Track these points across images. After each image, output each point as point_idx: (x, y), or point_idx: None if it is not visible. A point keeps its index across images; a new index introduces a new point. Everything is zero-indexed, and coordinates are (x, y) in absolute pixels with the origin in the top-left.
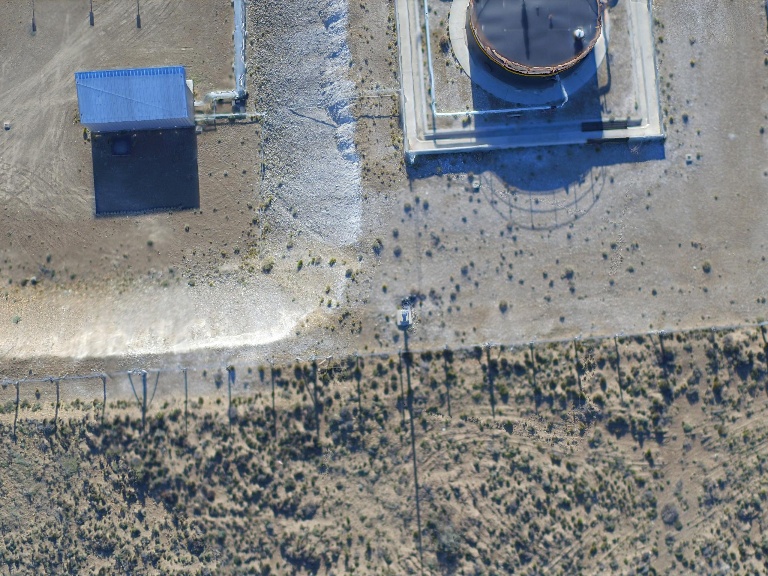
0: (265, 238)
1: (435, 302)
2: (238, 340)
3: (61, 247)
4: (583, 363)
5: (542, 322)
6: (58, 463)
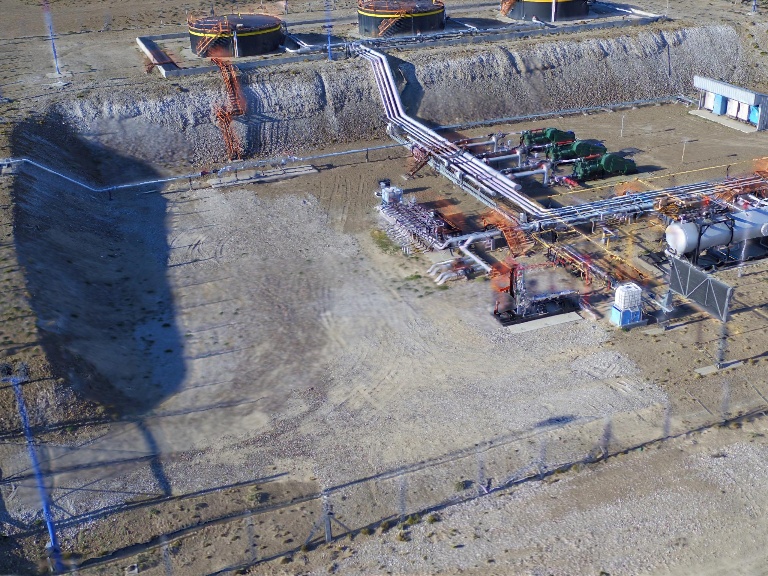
0: (760, 81)
1: None
2: None
3: None
4: None
5: None
6: None
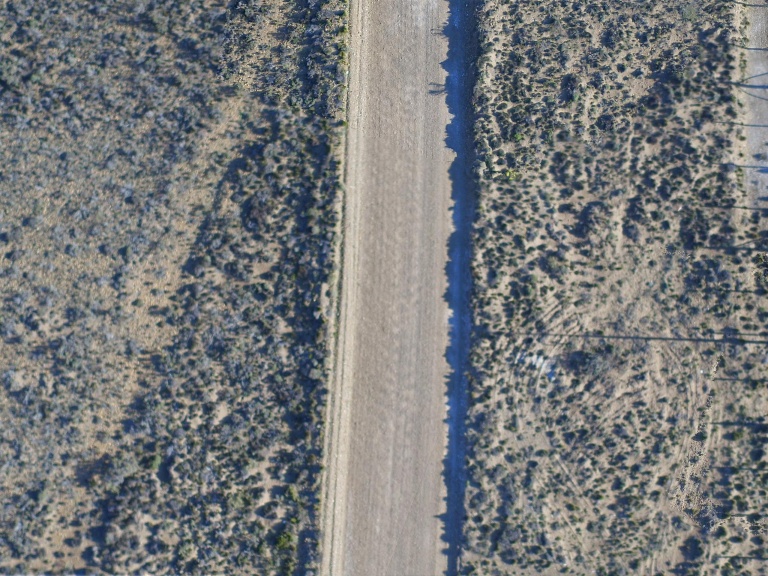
0: None
1: None
2: None
3: None
4: (760, 521)
5: None
6: (693, 1)
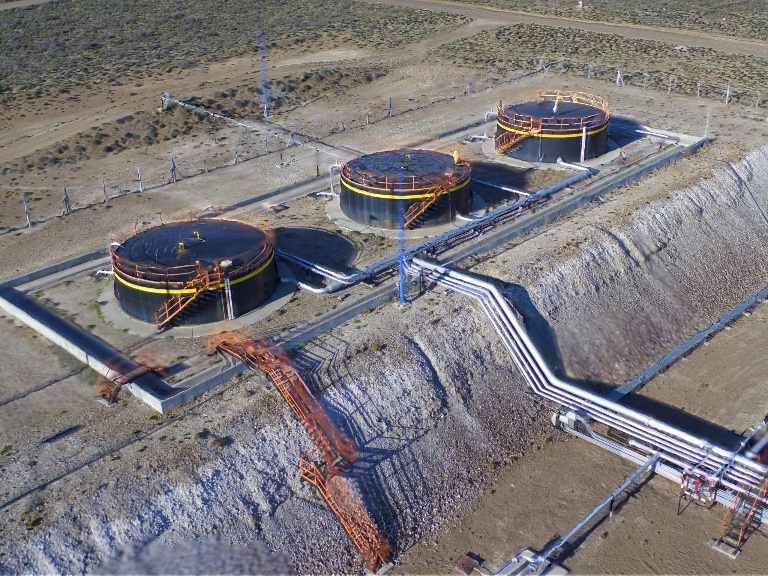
0: None
1: (746, 116)
2: None
3: None
4: None
5: (683, 100)
6: None
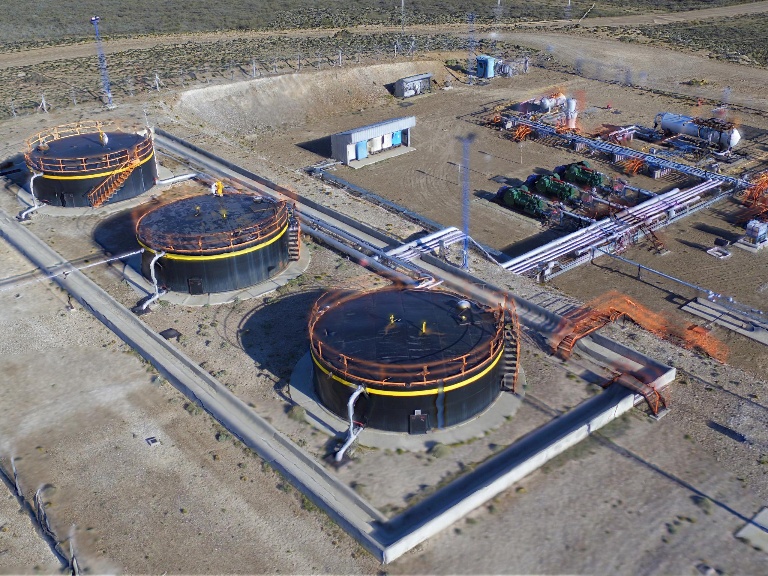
0: None
1: None
2: (213, 92)
3: (360, 118)
4: None
5: (12, 124)
6: None
